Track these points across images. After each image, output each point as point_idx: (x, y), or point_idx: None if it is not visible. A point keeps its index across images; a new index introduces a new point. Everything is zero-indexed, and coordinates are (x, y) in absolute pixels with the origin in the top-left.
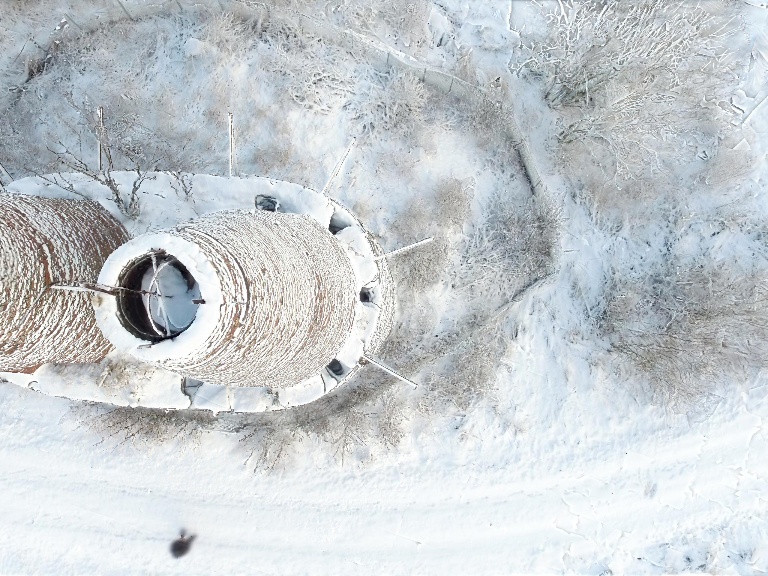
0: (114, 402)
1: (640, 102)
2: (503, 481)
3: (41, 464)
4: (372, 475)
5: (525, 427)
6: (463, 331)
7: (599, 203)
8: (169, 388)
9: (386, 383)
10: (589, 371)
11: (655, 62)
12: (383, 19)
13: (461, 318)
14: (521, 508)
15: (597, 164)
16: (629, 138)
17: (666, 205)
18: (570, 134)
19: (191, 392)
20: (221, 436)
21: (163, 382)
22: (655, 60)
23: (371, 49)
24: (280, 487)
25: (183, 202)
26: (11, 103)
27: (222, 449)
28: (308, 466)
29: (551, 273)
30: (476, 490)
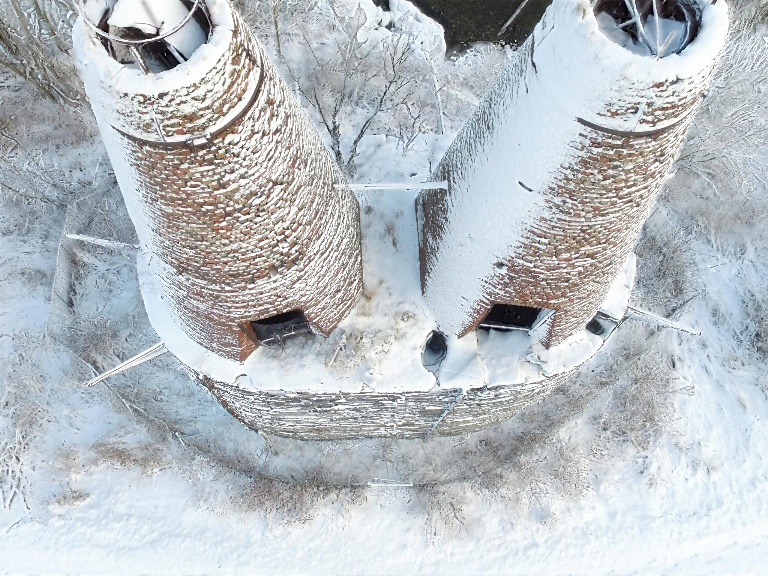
0: (344, 387)
1: (752, 113)
2: (711, 532)
3: (157, 569)
4: (557, 540)
5: (717, 464)
6: (620, 363)
7: (715, 229)
8: (409, 364)
9: (553, 425)
10: (764, 396)
11: (759, 75)
12: (466, 86)
13: (612, 351)
14: (740, 564)
15: (700, 196)
16: (743, 153)
17: None
18: None
19: (431, 370)
20: (375, 507)
21: (402, 356)
22: (758, 73)
23: (465, 106)
24: (450, 568)
25: (401, 157)
26: (108, 188)
27: (377, 525)
28: (480, 537)
29: (693, 297)
30: (682, 546)
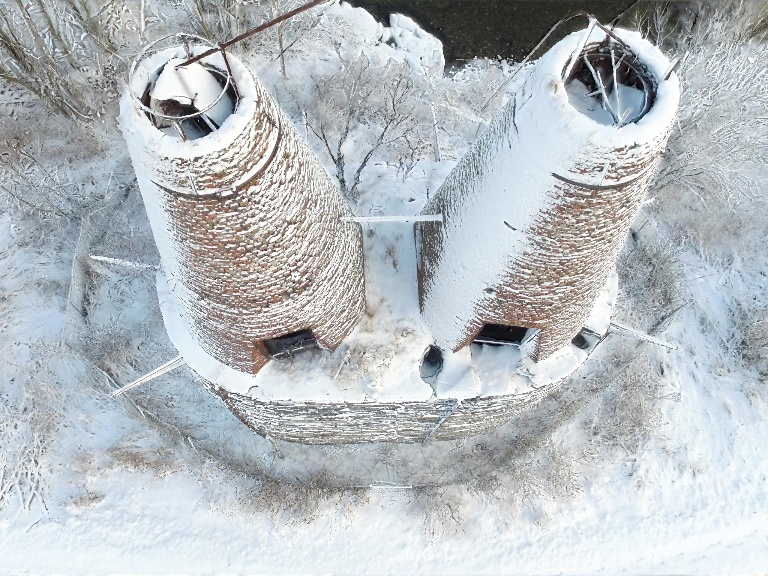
0: (348, 398)
1: (738, 130)
2: (696, 531)
3: (170, 567)
4: (549, 539)
5: (702, 467)
6: (611, 370)
7: (704, 240)
8: (408, 376)
9: (546, 430)
10: (748, 402)
11: (744, 93)
12: (464, 101)
13: (603, 359)
14: (724, 562)
15: (689, 208)
16: (729, 168)
17: (767, 237)
18: (662, 179)
19: (429, 382)
20: (376, 508)
21: (402, 369)
22: (744, 92)
23: (463, 121)
24: (447, 566)
25: (401, 184)
26: (119, 201)
27: (378, 525)
28: (476, 536)
29: (681, 306)
30: (669, 545)
